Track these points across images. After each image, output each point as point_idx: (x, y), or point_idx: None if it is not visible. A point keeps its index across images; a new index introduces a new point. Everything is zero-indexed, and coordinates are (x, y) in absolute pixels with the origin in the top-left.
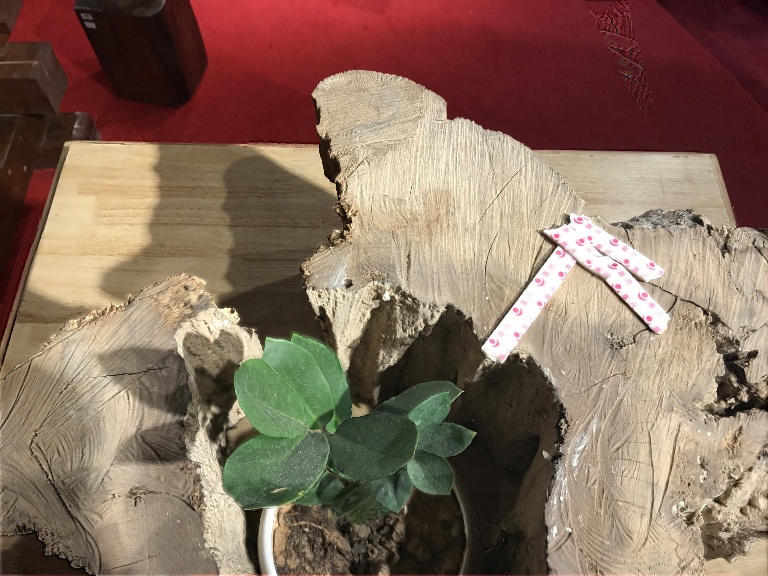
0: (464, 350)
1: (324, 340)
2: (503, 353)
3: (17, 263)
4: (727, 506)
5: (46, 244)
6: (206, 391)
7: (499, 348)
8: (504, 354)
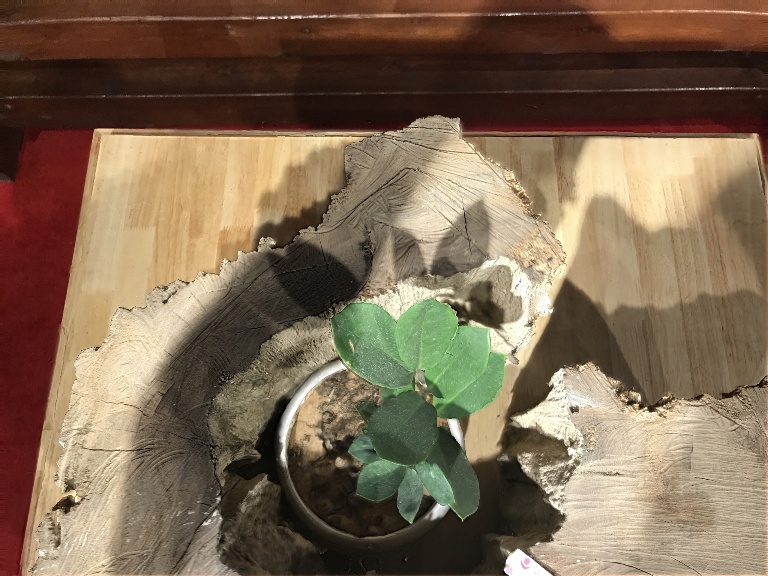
0: (529, 538)
1: None
2: (515, 572)
3: (612, 125)
4: None
5: (633, 143)
6: (478, 295)
7: (520, 568)
8: (513, 573)
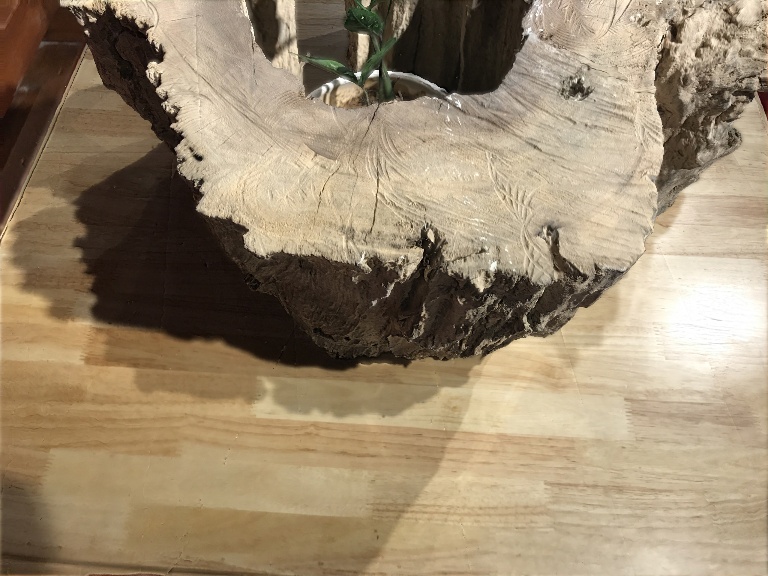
0: None
1: None
2: None
3: None
4: (682, 42)
5: None
6: None
7: None
8: None
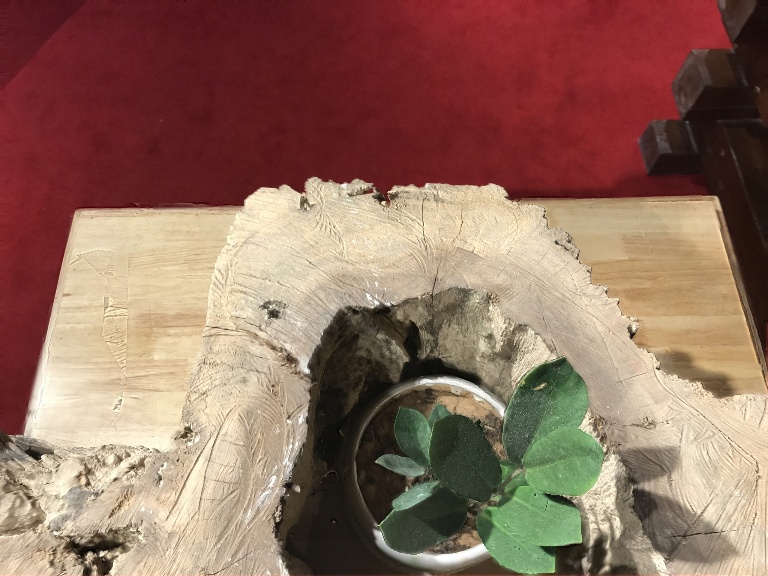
0: None
1: None
2: None
3: None
4: None
5: None
6: (620, 575)
7: None
8: None
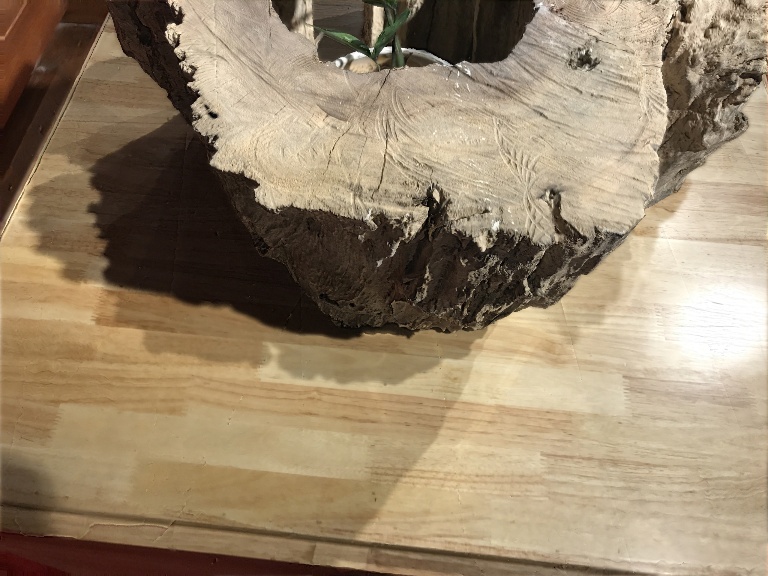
0: None
1: None
2: None
3: None
4: (691, 22)
5: None
6: None
7: None
8: None
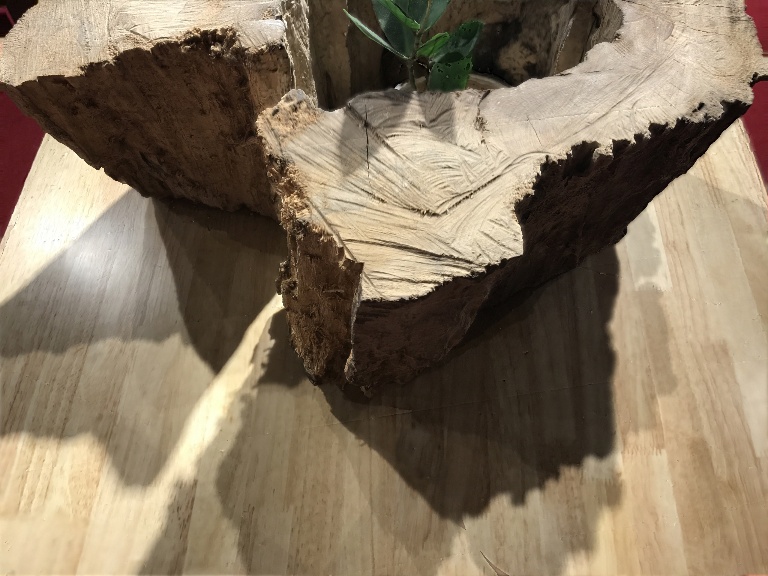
0: (327, 14)
1: (253, 245)
2: None
3: None
4: None
5: None
6: None
7: None
8: None
